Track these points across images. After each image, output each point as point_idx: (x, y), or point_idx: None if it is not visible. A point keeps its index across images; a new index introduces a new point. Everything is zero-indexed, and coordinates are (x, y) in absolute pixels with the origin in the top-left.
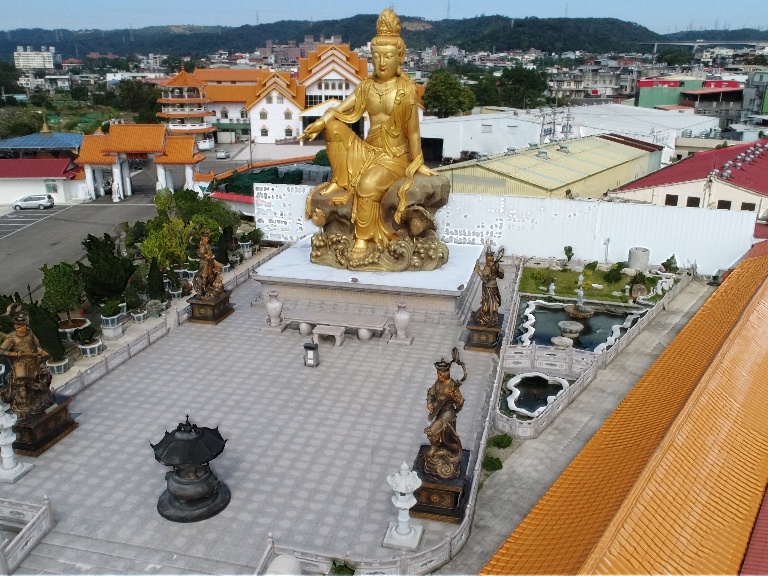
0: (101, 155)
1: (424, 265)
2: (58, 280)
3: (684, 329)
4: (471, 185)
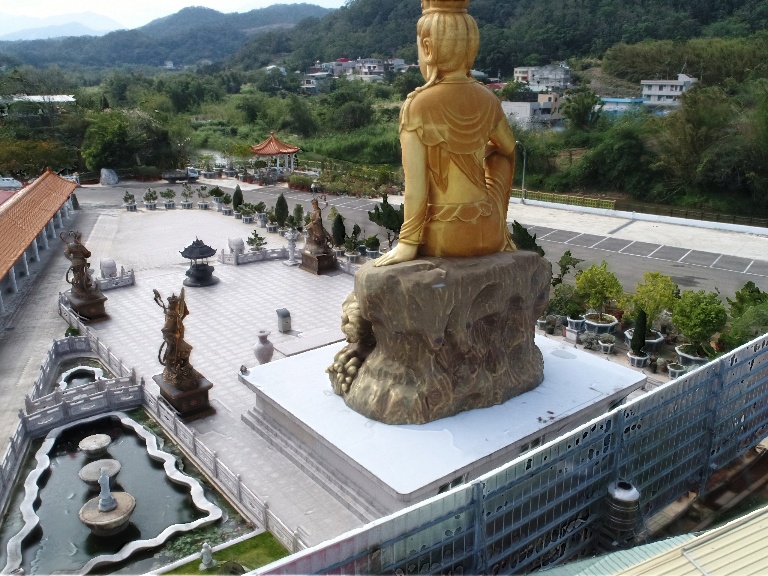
0: None
1: None
2: None
3: None
4: None
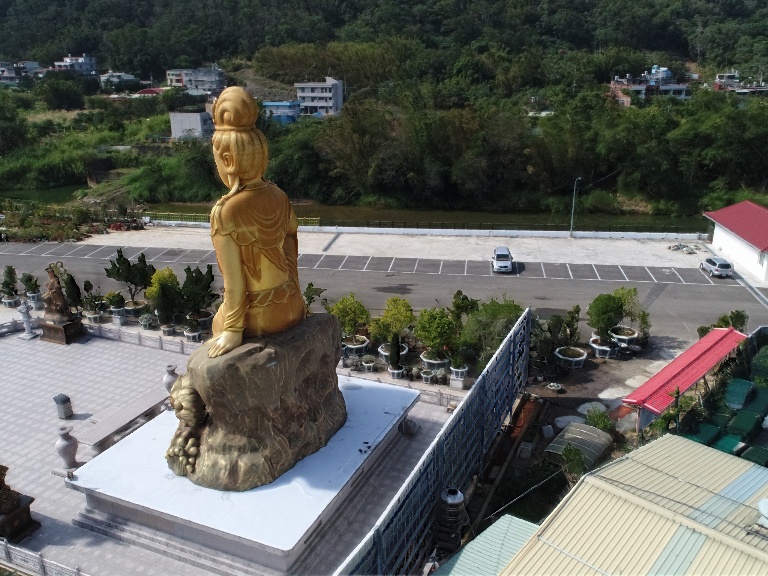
0: None
1: None
2: None
3: None
4: None
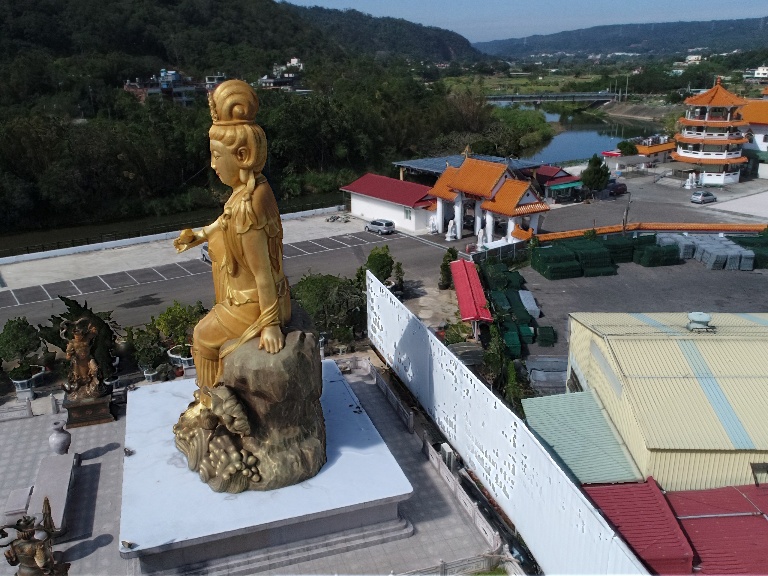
0: (448, 190)
1: (215, 477)
2: (4, 332)
3: None
4: (600, 369)
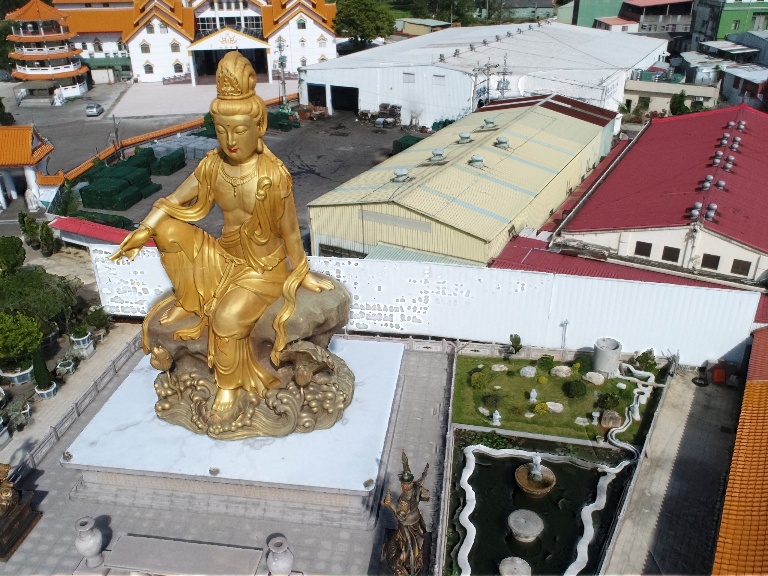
0: None
1: (318, 421)
2: None
3: None
4: (386, 225)
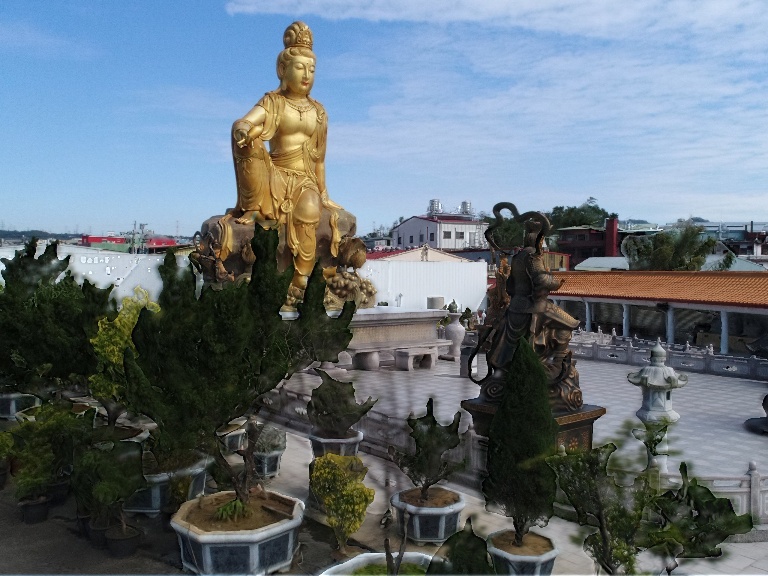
0: None
1: None
2: None
3: (648, 296)
4: None
